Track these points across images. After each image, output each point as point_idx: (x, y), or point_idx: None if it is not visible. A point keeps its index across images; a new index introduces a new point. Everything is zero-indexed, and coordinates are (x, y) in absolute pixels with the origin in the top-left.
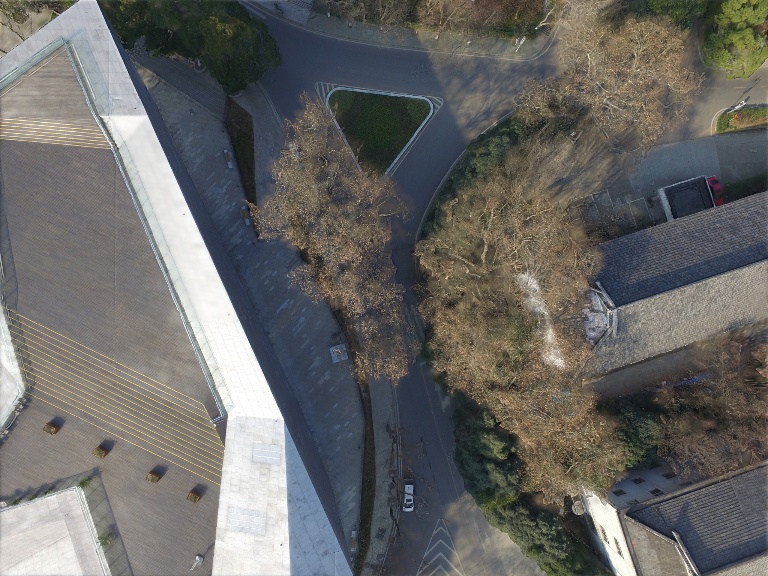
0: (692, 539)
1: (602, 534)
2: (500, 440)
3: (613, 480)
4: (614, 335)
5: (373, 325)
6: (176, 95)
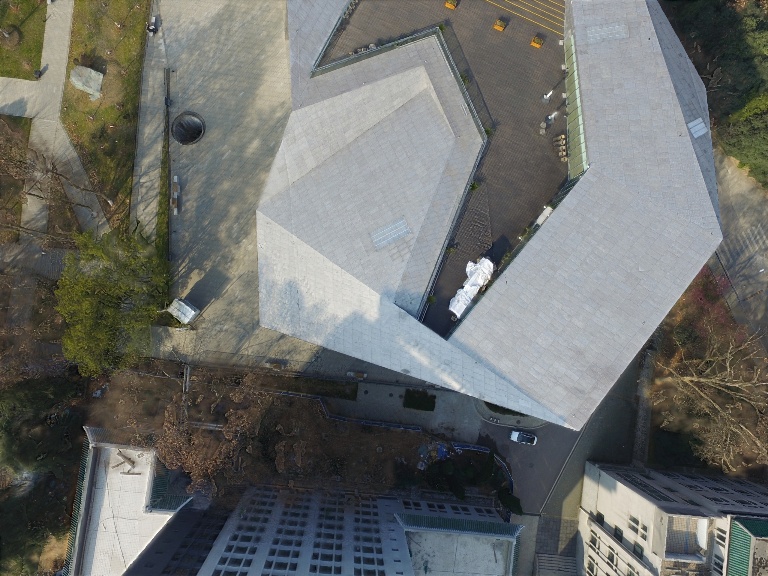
0: None
1: None
2: None
3: None
4: None
5: None
6: None
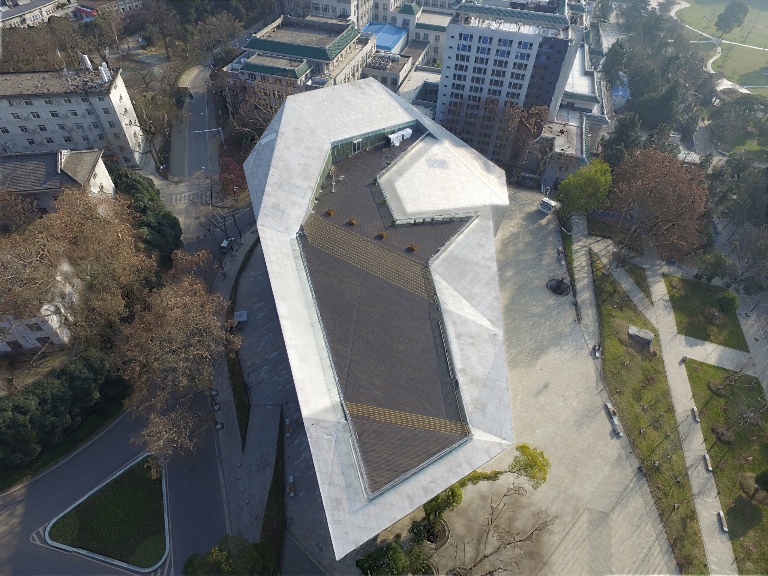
0: (51, 168)
1: None
2: (139, 232)
3: None
4: None
5: None
6: (335, 572)
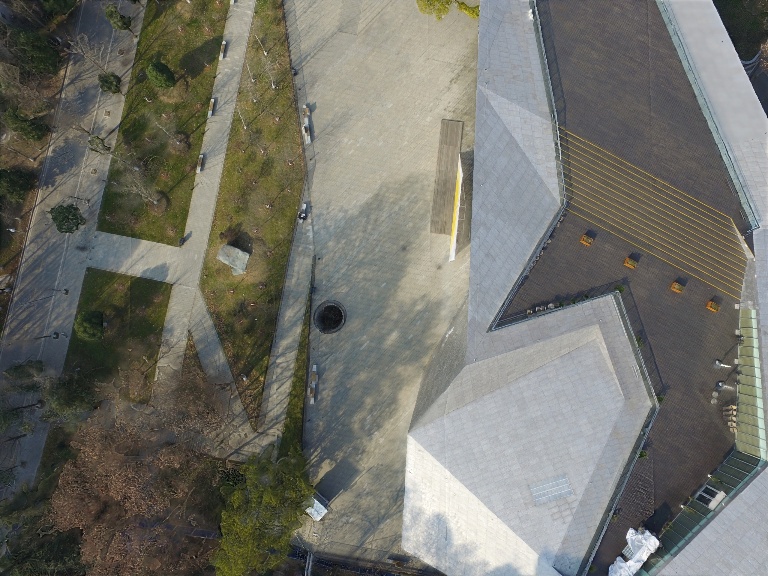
0: None
1: None
2: None
3: None
4: None
5: None
6: None
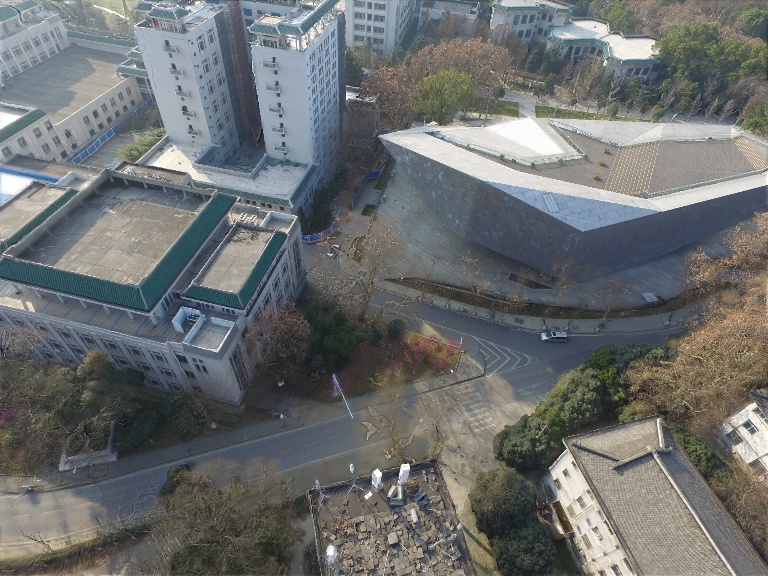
0: None
1: None
2: None
3: None
4: None
5: None
6: None
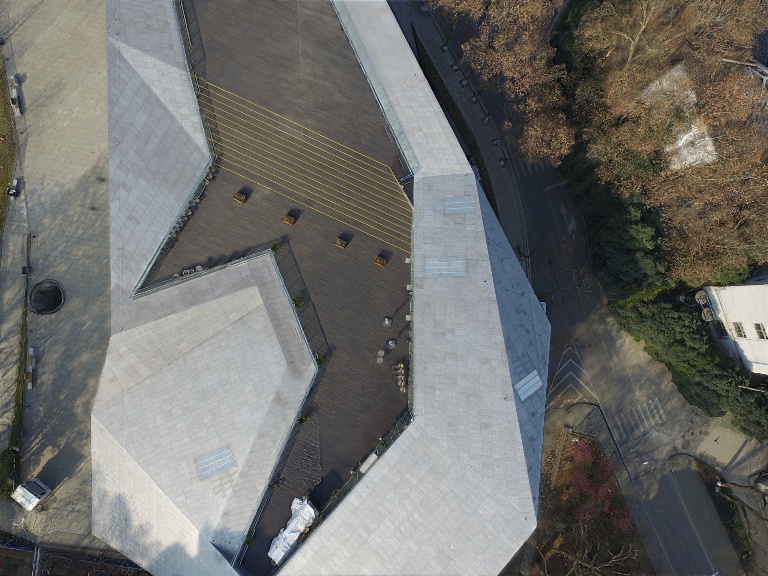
0: None
1: (736, 332)
2: (651, 226)
3: (751, 272)
4: (767, 107)
5: (537, 104)
6: None
